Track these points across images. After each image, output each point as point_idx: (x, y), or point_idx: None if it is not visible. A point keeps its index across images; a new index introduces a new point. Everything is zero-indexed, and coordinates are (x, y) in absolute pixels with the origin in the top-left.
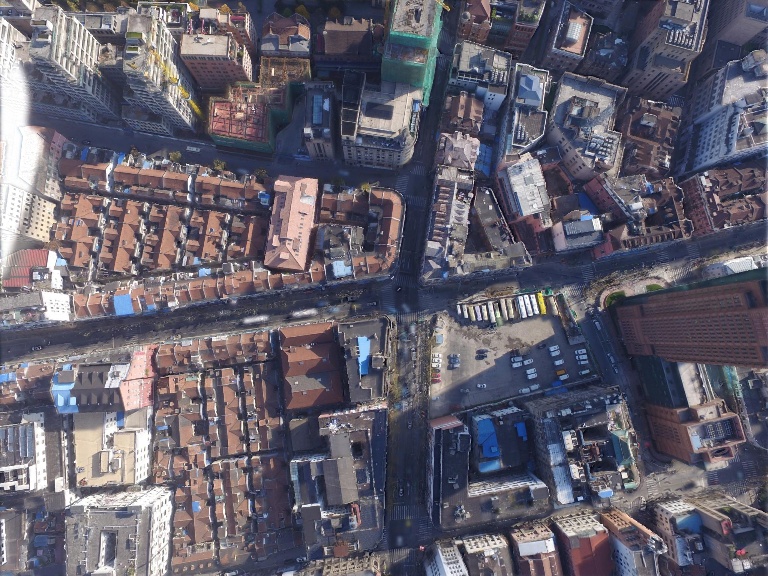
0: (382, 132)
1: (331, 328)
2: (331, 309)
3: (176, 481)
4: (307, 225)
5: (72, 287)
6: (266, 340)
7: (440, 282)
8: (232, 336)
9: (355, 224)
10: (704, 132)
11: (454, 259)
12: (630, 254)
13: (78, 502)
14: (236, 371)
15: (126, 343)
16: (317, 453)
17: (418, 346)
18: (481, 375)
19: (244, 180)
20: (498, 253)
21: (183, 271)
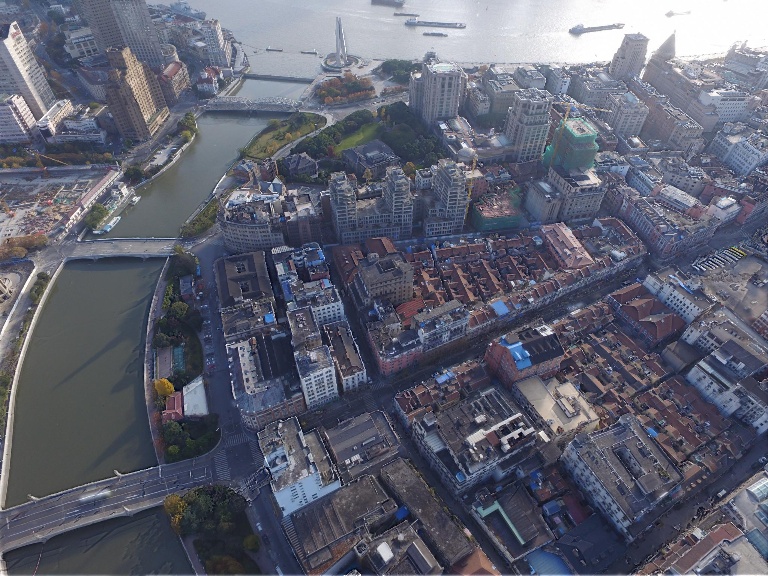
0: (590, 185)
1: None
2: None
3: None
4: (577, 242)
5: None
6: (606, 304)
7: (673, 255)
8: (581, 310)
9: None
10: (732, 163)
11: None
12: (755, 220)
13: None
14: None
15: None
16: None
17: None
18: (747, 298)
19: (518, 236)
20: (698, 221)
21: None
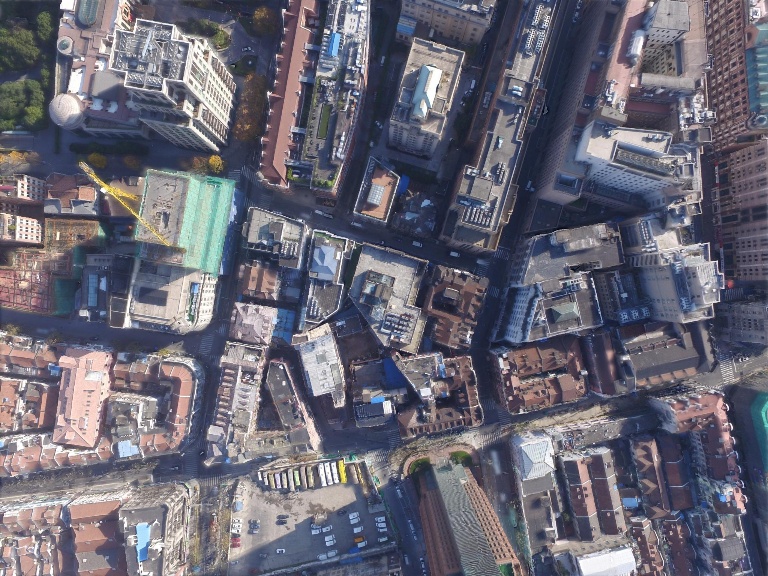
0: (157, 319)
1: (120, 506)
2: (134, 472)
3: None
4: (95, 401)
5: None
6: (57, 516)
7: None
8: (24, 511)
9: None
10: (517, 299)
11: (236, 446)
12: None
13: None
14: (37, 537)
15: None
16: None
17: (220, 510)
18: (281, 540)
19: (35, 349)
20: (282, 439)
21: None
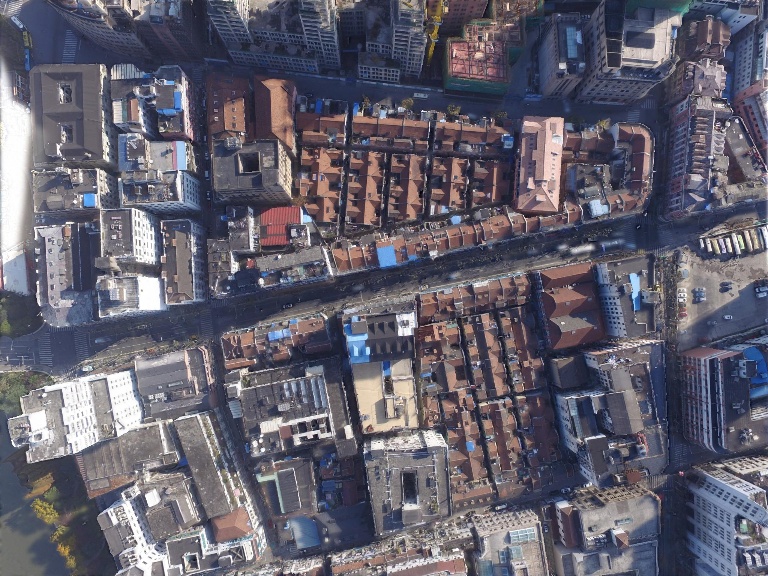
0: (644, 62)
1: (591, 268)
2: (573, 251)
3: (445, 424)
4: (558, 166)
5: (319, 243)
6: (527, 283)
7: (685, 217)
8: (491, 281)
9: (595, 163)
10: None
11: (717, 190)
12: None
13: (370, 447)
14: (489, 316)
15: (374, 296)
16: (583, 390)
17: (662, 282)
18: (726, 307)
19: (484, 124)
20: (760, 182)
21: (426, 221)
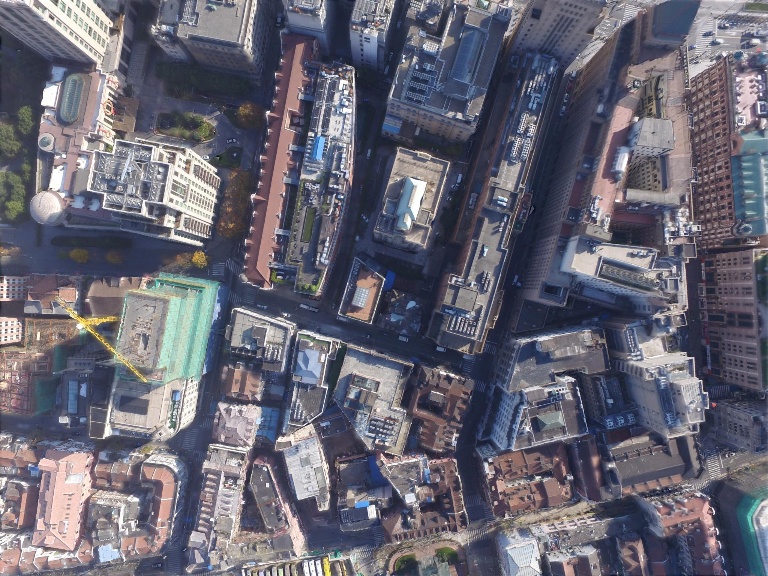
0: (138, 427)
1: None
2: (116, 570)
3: None
4: (75, 504)
5: None
6: None
7: None
8: None
9: None
10: (503, 398)
11: (218, 553)
12: None
13: None
14: None
15: None
16: None
17: None
18: None
19: (15, 449)
20: (265, 545)
21: None
